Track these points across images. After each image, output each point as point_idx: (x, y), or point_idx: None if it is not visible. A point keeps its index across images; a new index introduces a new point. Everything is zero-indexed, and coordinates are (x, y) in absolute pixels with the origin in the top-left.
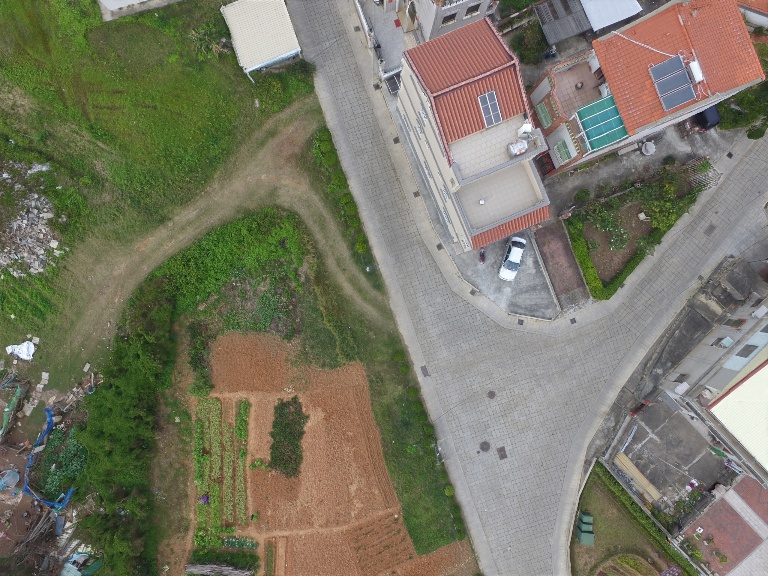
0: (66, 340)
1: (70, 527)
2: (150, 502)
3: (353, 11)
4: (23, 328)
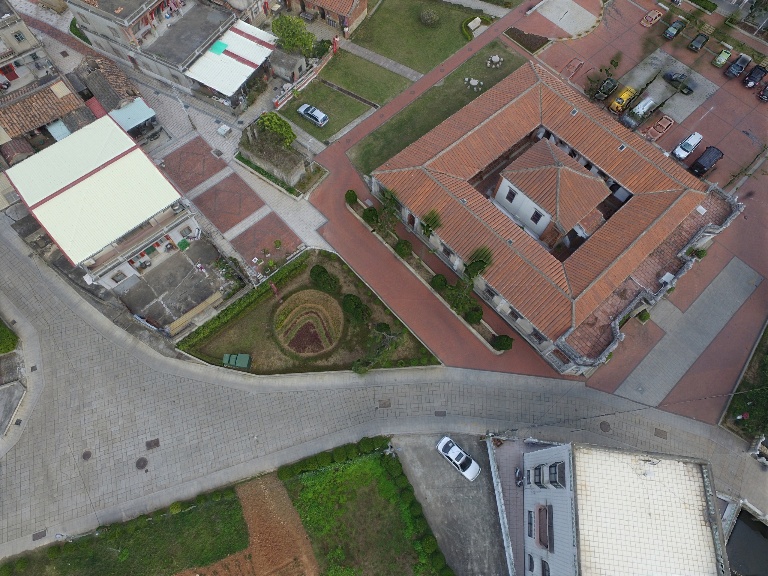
0: None
1: None
2: None
3: None
4: None
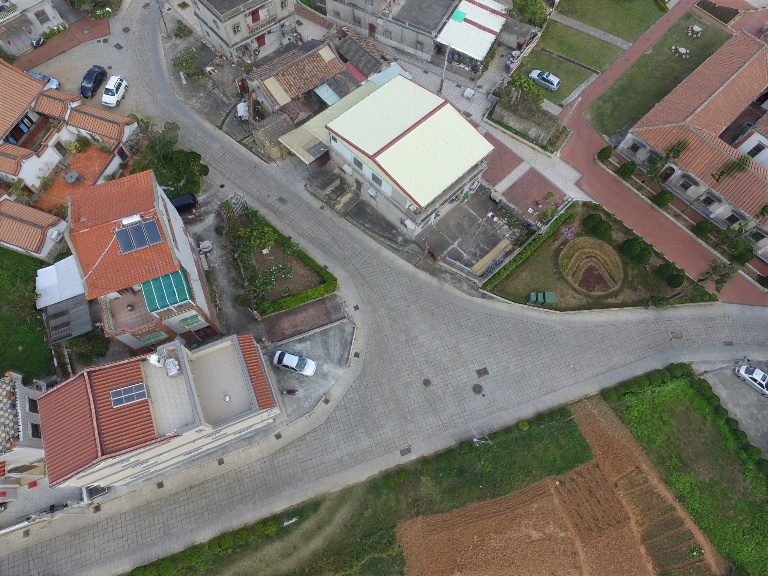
0: None
1: None
2: None
3: (4, 539)
4: None
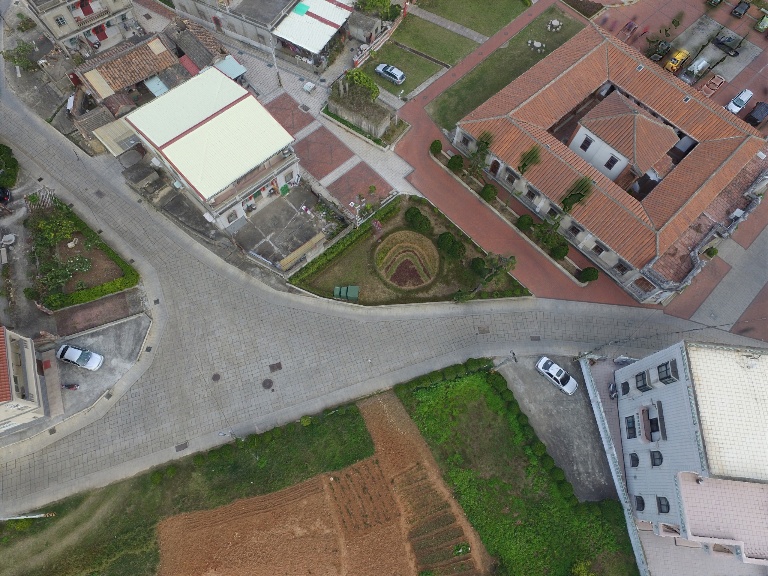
0: None
1: None
2: None
3: None
4: None
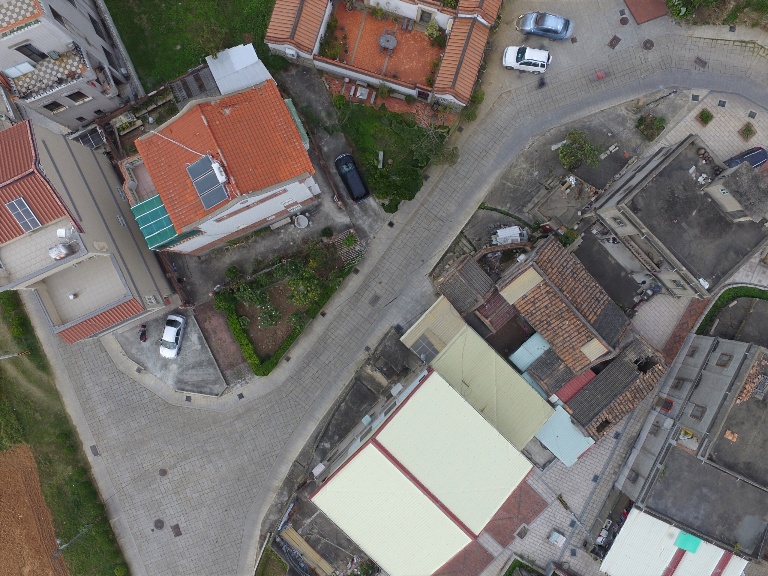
0: None
1: None
2: None
3: None
4: None
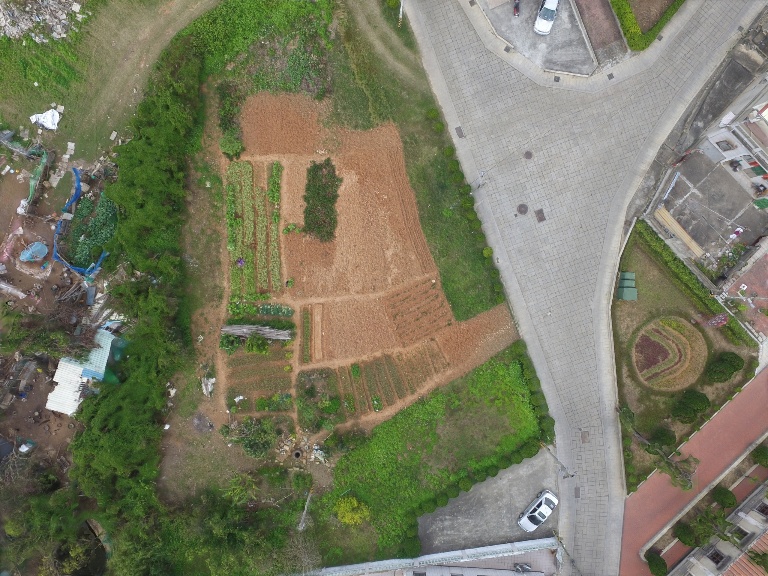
0: (91, 108)
1: (101, 298)
2: (182, 268)
3: None
4: (47, 96)
